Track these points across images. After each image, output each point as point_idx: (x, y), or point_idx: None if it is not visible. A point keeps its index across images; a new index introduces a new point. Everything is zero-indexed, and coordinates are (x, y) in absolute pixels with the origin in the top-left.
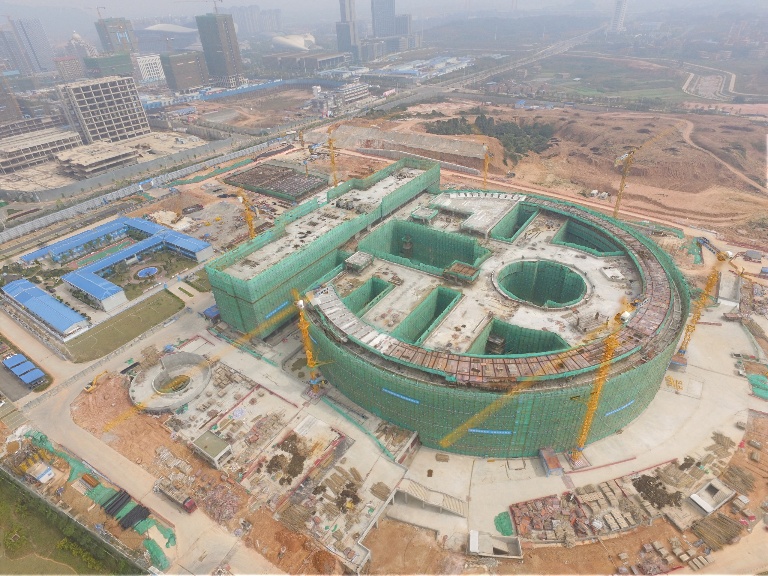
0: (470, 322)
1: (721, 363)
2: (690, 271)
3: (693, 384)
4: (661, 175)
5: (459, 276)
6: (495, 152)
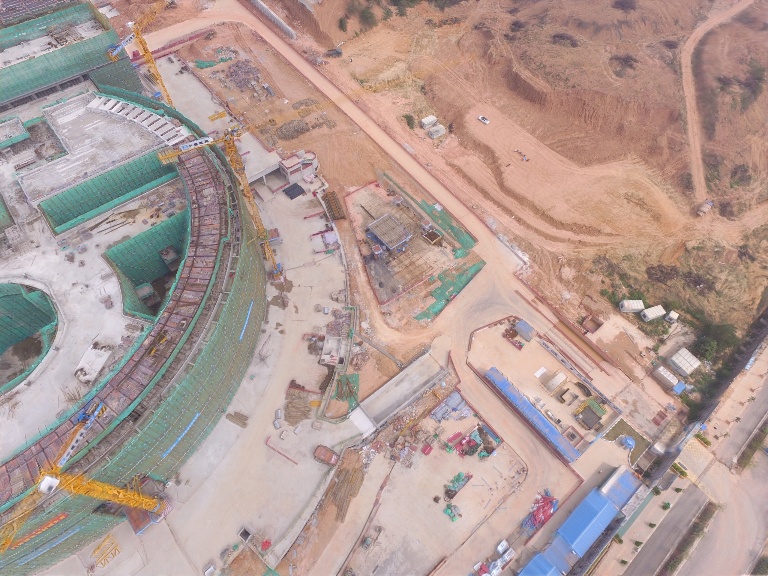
0: None
1: (210, 539)
2: (387, 333)
3: (129, 563)
4: (568, 111)
5: None
6: (336, 0)
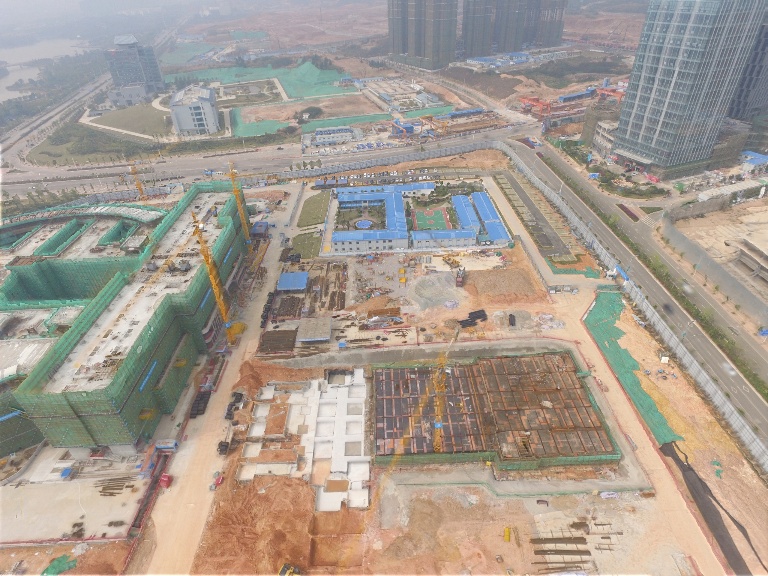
0: (31, 245)
1: None
2: None
3: None
4: None
5: (31, 257)
6: None
